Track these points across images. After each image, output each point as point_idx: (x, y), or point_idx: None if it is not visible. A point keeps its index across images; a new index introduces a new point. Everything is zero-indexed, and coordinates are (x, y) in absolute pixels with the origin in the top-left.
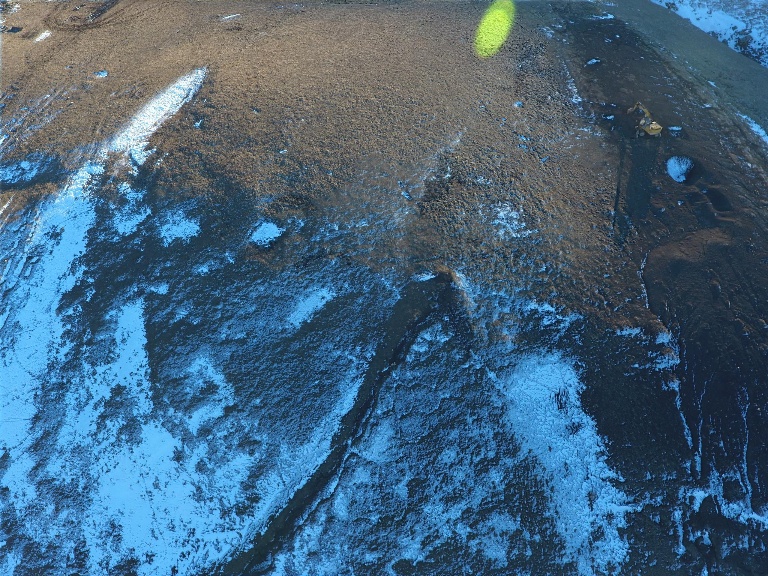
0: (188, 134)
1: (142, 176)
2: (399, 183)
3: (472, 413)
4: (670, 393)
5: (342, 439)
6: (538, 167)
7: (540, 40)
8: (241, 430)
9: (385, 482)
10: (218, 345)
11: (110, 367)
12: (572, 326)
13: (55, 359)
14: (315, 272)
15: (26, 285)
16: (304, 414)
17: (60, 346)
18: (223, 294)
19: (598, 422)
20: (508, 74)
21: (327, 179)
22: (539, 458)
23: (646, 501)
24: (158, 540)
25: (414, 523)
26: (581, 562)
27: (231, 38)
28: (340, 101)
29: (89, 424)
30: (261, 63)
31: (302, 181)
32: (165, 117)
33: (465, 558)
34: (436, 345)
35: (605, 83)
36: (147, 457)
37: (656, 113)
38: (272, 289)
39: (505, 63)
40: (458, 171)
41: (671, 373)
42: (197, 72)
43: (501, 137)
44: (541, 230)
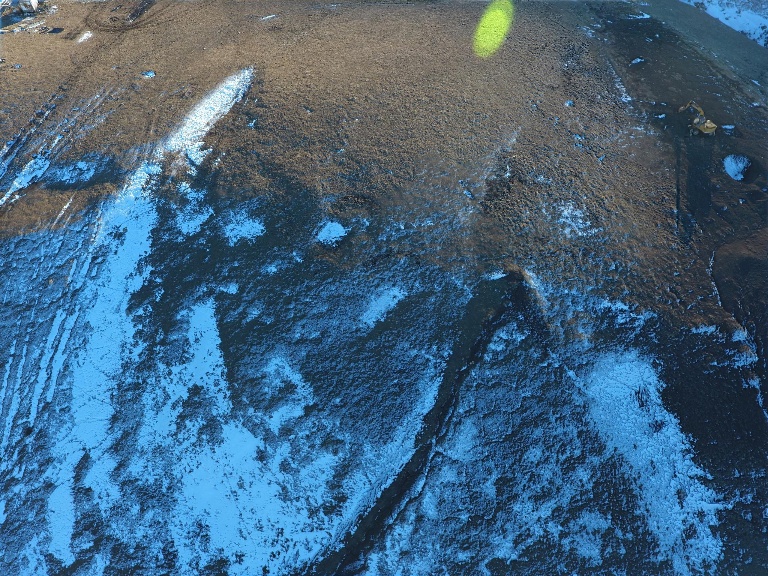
0: (243, 134)
1: (201, 176)
2: (460, 182)
3: (554, 411)
4: (751, 391)
5: (426, 438)
6: (596, 166)
7: (582, 39)
8: (323, 429)
9: (472, 481)
10: (293, 345)
11: (185, 367)
12: (647, 324)
13: (129, 359)
14: (385, 271)
15: (93, 285)
16: (385, 413)
17: (133, 346)
18: (294, 294)
19: (681, 420)
20: (555, 73)
21: (388, 178)
22: (625, 456)
23: (736, 499)
24: (247, 540)
25: (505, 522)
26: (676, 560)
27: (273, 38)
28: (392, 101)
29: (168, 424)
30: (308, 63)
31: (363, 180)
32: (217, 117)
33: (559, 557)
34: (513, 344)
35: (653, 82)
36: (230, 457)
37: (707, 112)
38: (343, 288)
39: (551, 62)
40: (518, 170)
41: (750, 371)
42: (244, 72)
43: (556, 136)
44: (606, 229)
